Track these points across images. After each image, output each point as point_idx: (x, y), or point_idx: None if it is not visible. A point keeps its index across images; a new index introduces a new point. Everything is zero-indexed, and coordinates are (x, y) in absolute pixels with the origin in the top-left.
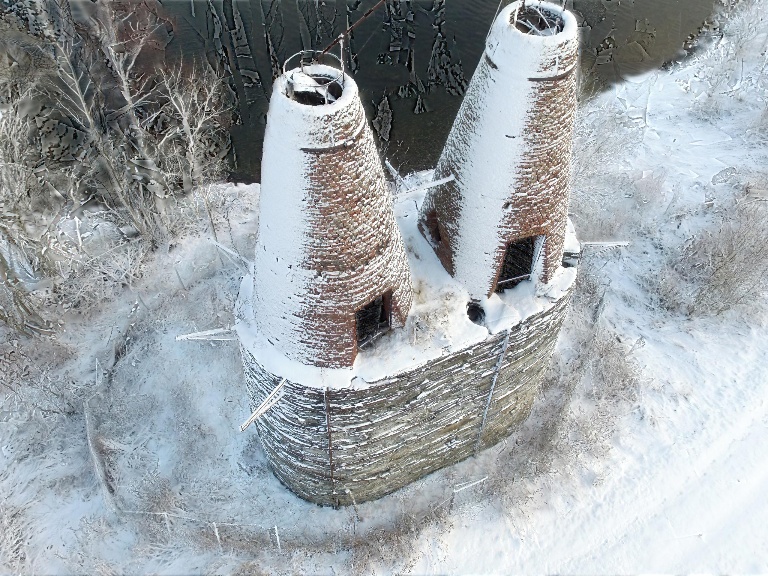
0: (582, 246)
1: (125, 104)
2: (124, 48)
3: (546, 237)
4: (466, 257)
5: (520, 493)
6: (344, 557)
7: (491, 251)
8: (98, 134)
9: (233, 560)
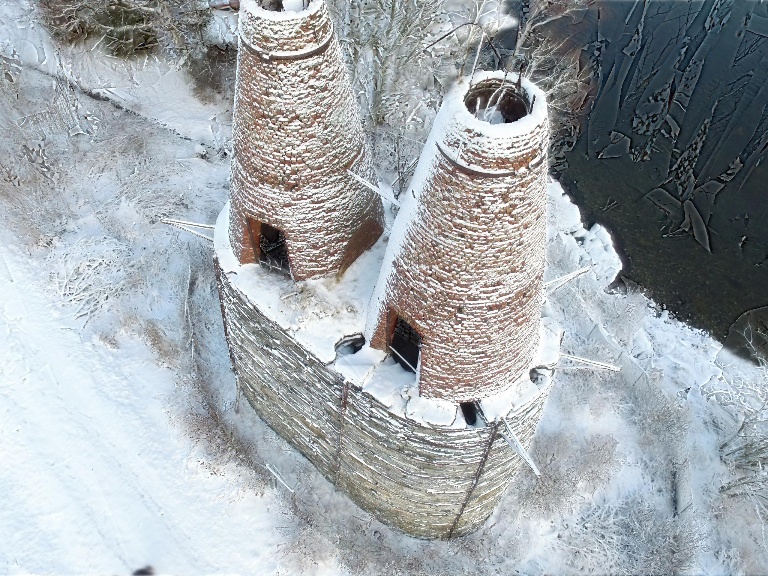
0: (497, 420)
1: (512, 48)
2: (536, 1)
3: (423, 341)
4: (375, 289)
5: (320, 551)
6: (202, 412)
7: (380, 300)
8: (467, 50)
9: (180, 337)
